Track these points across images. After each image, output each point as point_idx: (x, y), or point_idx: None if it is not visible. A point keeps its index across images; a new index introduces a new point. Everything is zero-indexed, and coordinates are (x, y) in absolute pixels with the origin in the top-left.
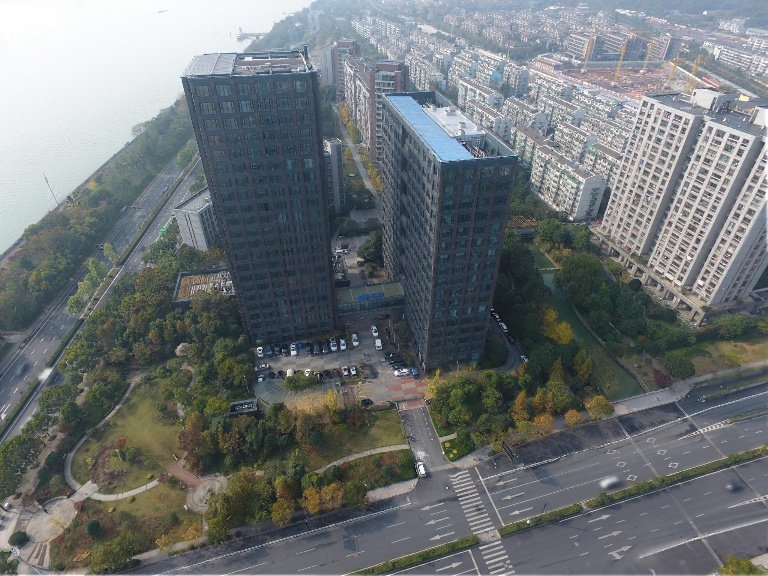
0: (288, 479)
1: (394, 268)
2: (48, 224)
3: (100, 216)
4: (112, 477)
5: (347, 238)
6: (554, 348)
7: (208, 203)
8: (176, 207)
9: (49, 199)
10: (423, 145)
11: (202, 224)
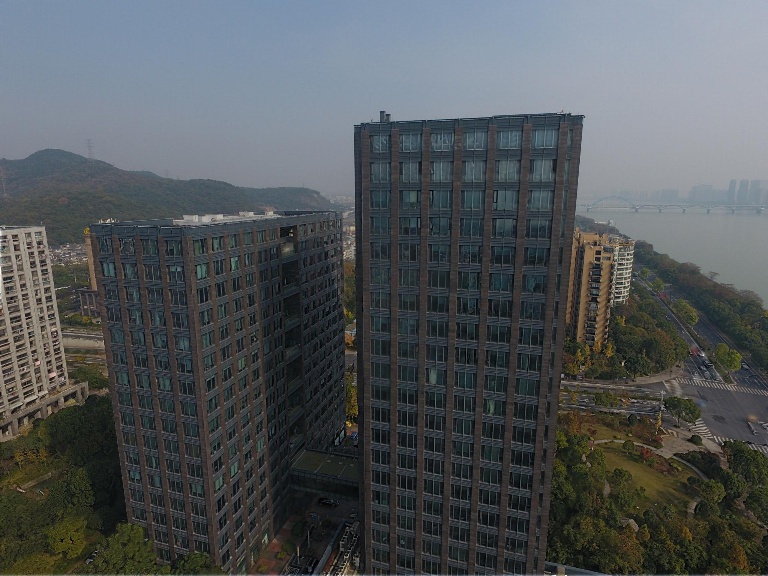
0: None
1: (274, 483)
2: None
3: None
4: None
5: None
6: None
7: None
8: None
9: None
10: (322, 216)
11: None
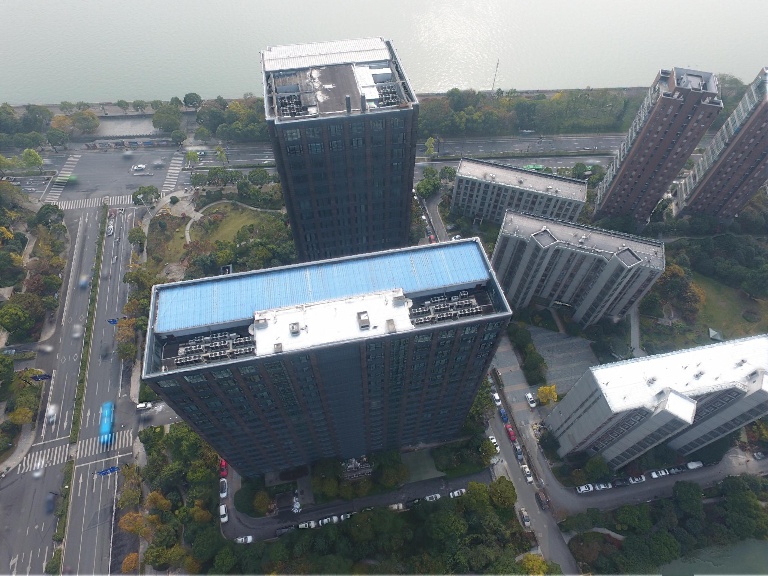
0: (139, 305)
1: None
2: (458, 96)
3: (489, 120)
4: (200, 224)
5: (507, 337)
6: (222, 570)
7: (479, 178)
8: (466, 157)
9: (488, 80)
10: None
11: (457, 187)
